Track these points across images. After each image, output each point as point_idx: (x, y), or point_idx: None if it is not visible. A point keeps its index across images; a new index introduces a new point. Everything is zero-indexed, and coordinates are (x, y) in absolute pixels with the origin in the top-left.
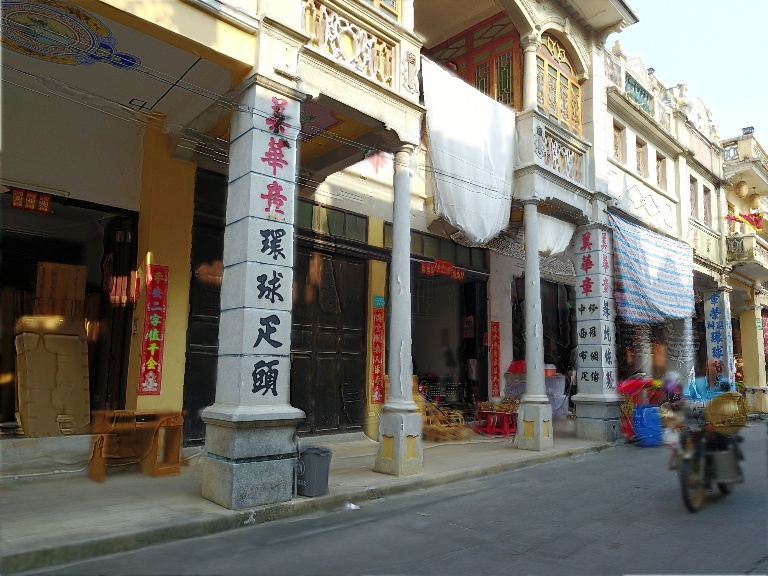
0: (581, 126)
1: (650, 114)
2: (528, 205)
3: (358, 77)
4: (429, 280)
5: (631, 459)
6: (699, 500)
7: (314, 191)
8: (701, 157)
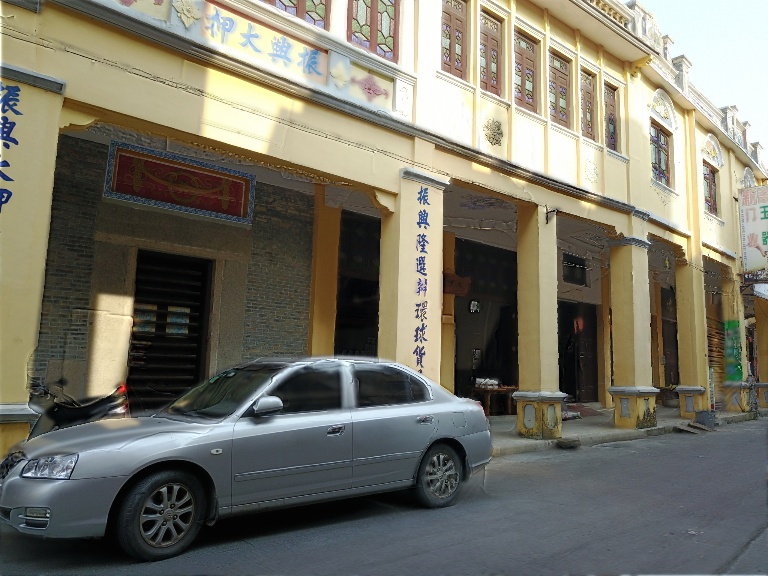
0: None
1: None
2: None
3: None
4: None
5: None
6: None
7: None
8: None
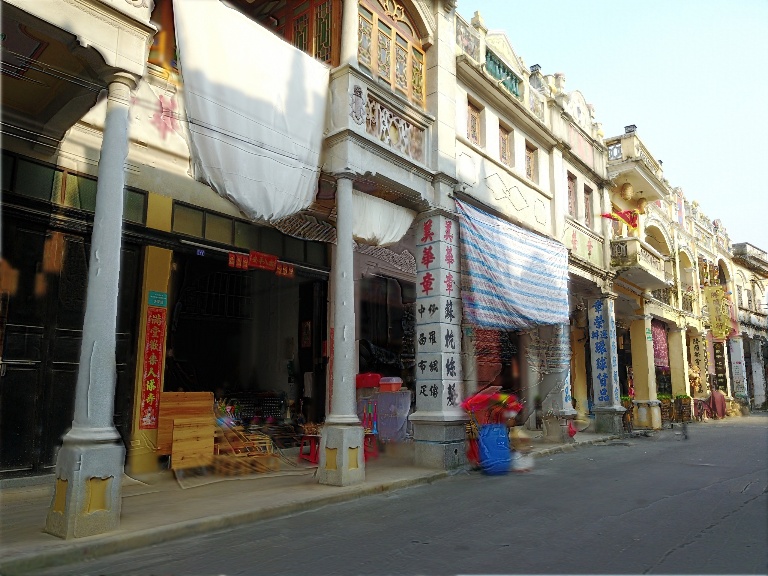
0: (425, 98)
1: (519, 99)
2: (341, 179)
3: None
4: (242, 276)
5: (457, 493)
6: (474, 564)
7: (54, 151)
8: (581, 153)
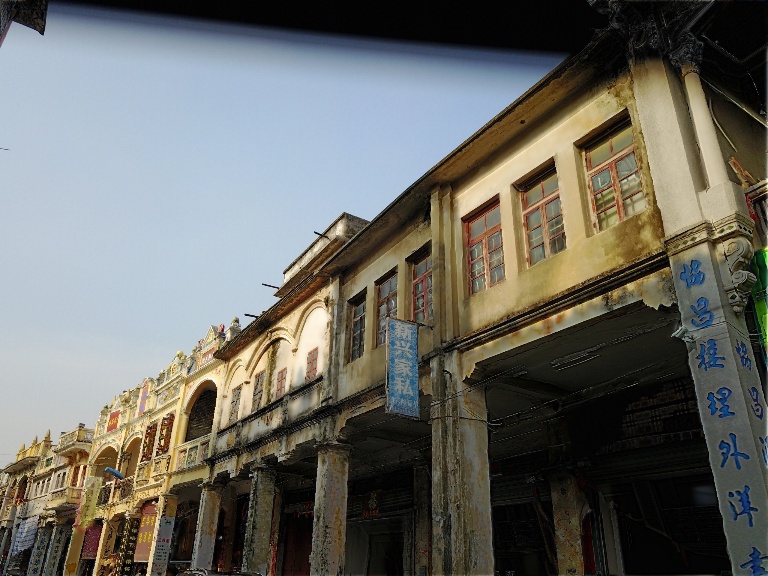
0: None
1: None
2: None
3: (3, 521)
4: None
5: None
6: None
7: None
8: None
